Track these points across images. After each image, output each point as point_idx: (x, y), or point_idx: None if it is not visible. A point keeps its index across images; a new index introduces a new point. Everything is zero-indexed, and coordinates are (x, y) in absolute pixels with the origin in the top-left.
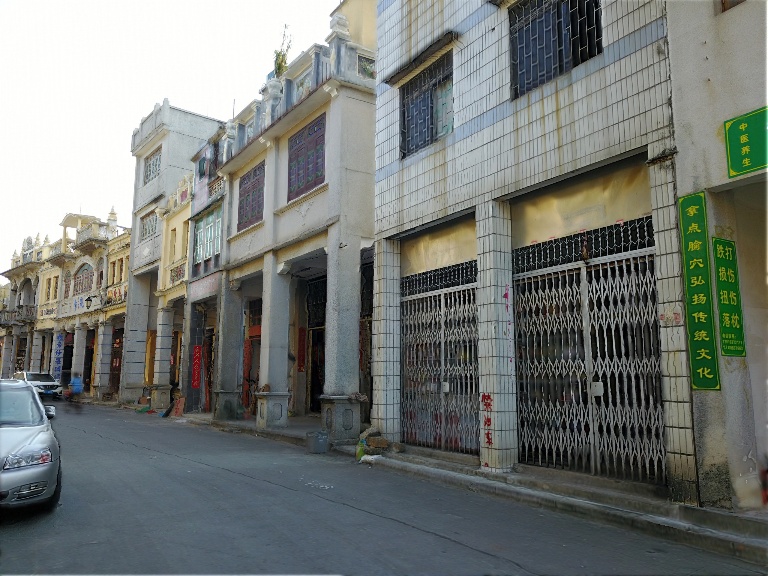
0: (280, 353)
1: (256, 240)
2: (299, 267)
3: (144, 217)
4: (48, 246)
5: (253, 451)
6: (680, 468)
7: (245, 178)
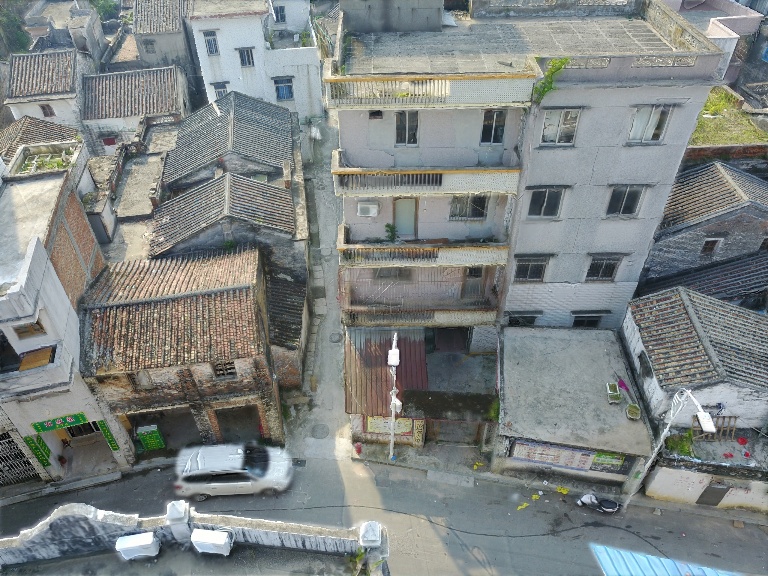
0: None
1: None
2: None
3: None
4: None
5: None
6: (46, 478)
7: None
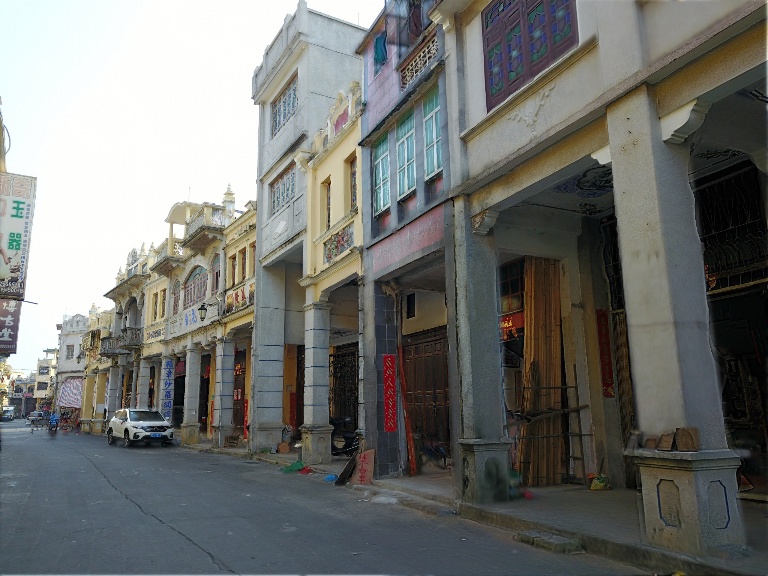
0: (698, 343)
1: (558, 98)
2: (710, 125)
3: (274, 181)
4: (153, 251)
5: None
6: None
7: (499, 1)
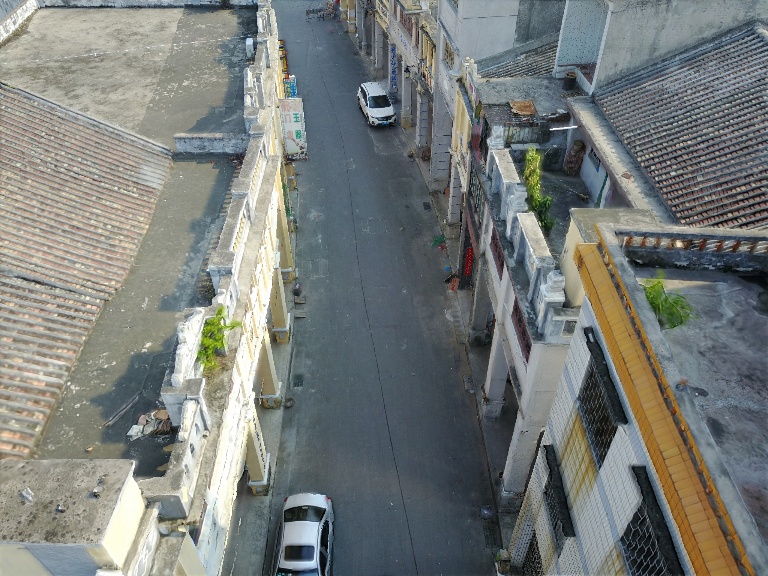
0: (499, 382)
1: (497, 284)
2: None
3: None
4: None
5: (453, 490)
6: None
7: None
